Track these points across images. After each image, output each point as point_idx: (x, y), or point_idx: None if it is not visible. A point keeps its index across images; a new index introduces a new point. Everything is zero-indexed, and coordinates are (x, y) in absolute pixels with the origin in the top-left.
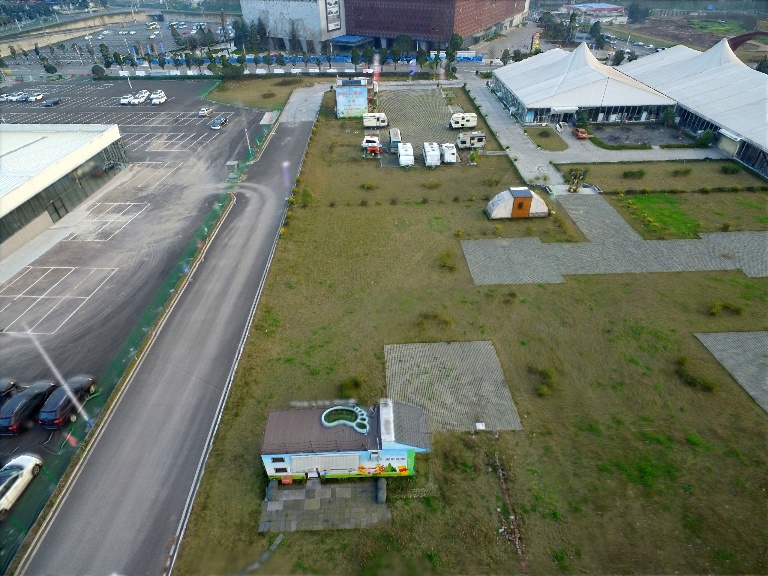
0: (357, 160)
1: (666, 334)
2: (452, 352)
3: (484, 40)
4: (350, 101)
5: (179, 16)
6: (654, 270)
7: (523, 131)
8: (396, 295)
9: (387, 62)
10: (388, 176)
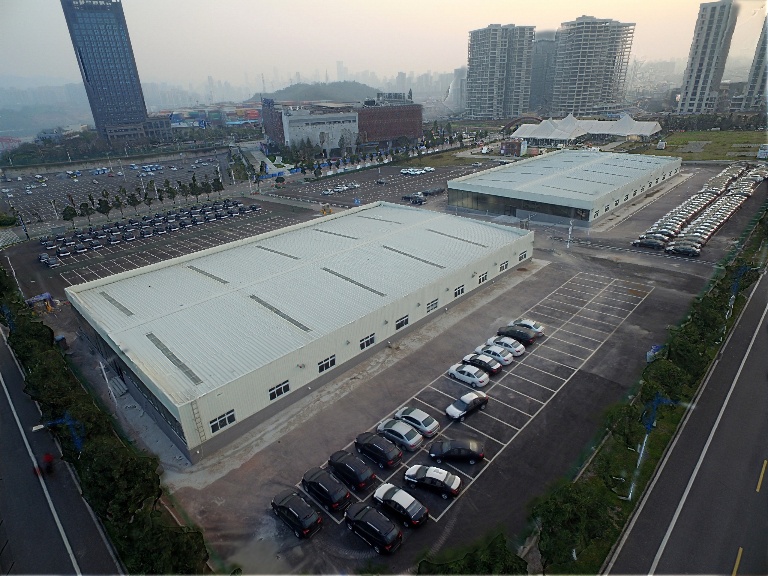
0: None
1: None
2: None
3: None
4: None
5: (36, 169)
6: None
7: (574, 147)
8: None
9: None
10: None
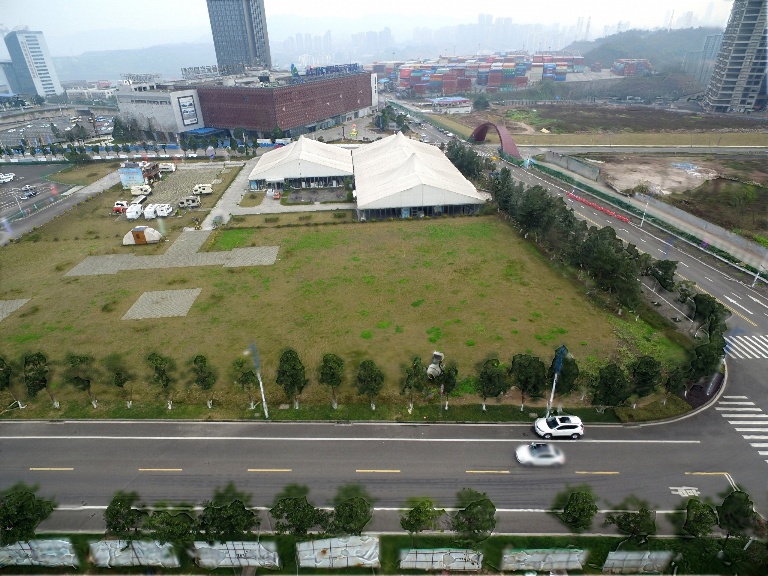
0: (104, 217)
1: (130, 292)
2: (2, 303)
3: (322, 129)
4: (130, 178)
5: (103, 111)
6: (175, 266)
7: (244, 195)
8: (11, 283)
9: (221, 148)
10: (113, 226)
